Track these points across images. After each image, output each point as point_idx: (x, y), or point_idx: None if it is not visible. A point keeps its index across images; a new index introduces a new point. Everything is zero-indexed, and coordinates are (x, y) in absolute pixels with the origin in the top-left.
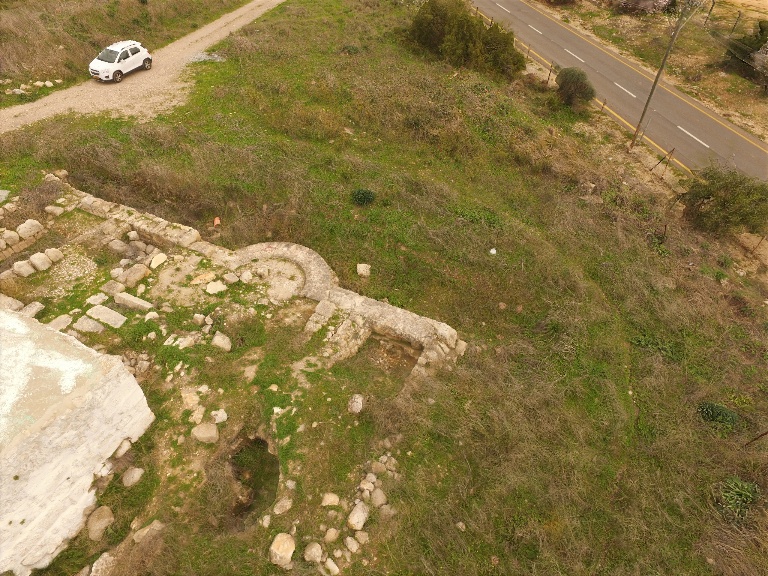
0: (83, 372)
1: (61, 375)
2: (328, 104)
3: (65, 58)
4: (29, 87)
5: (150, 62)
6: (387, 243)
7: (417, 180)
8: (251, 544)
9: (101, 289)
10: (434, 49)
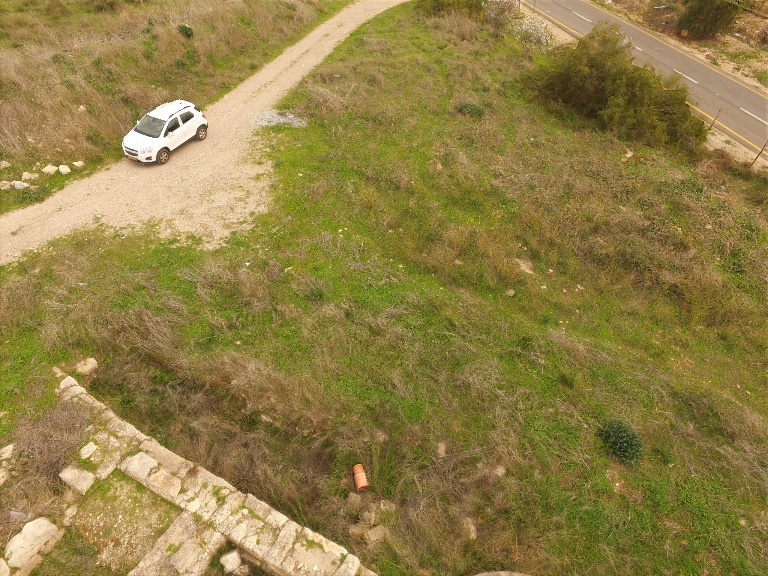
0: None
1: None
2: (475, 210)
3: (87, 126)
4: (35, 176)
5: (205, 129)
6: (705, 569)
7: (687, 390)
8: None
9: None
10: (584, 111)
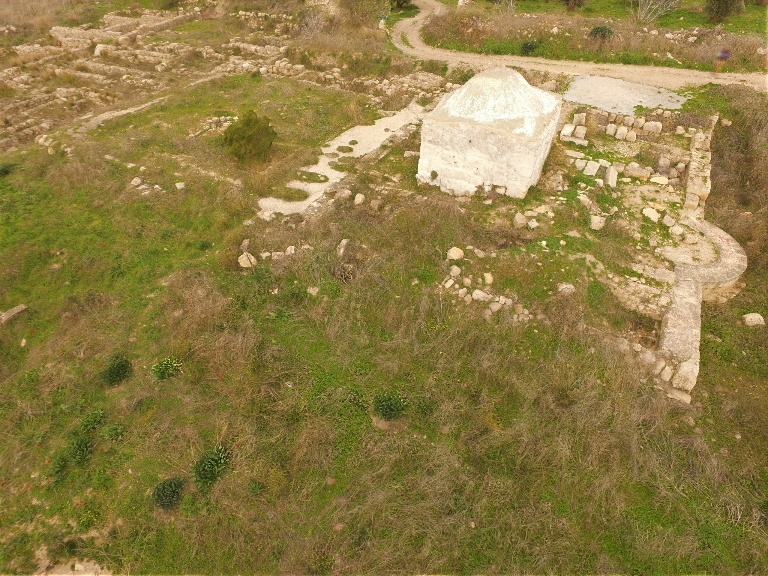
0: (527, 134)
1: (522, 127)
2: None
3: None
4: None
5: None
6: None
7: None
8: (456, 243)
9: (614, 162)
10: None
